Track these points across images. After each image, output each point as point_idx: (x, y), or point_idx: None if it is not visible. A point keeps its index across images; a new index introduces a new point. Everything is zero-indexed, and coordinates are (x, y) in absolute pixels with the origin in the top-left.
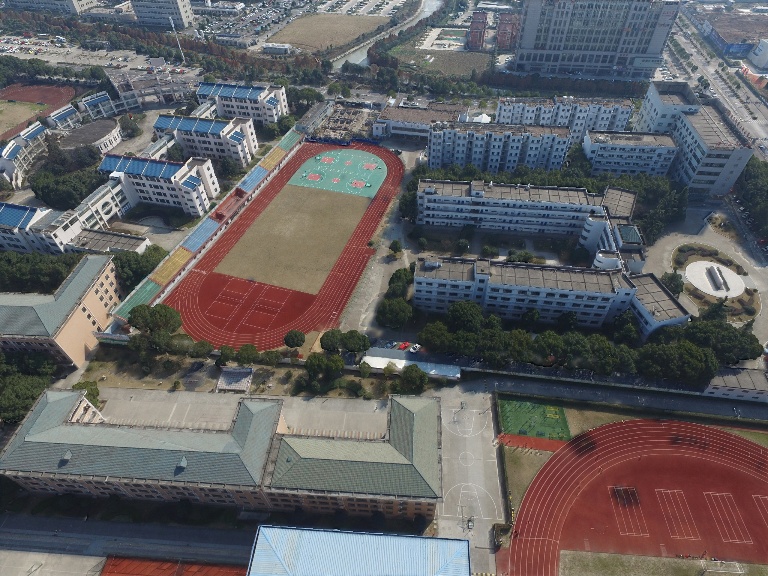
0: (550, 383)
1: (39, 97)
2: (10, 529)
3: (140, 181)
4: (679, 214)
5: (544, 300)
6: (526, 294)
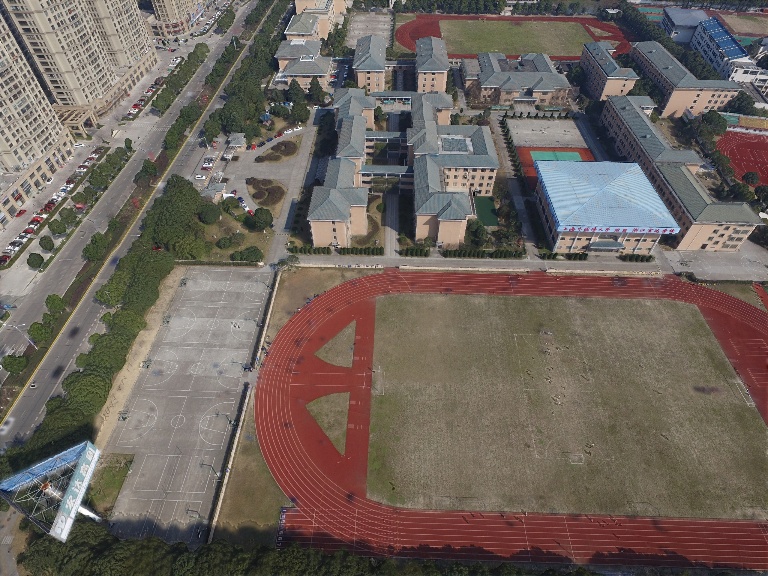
0: None
1: None
2: (582, 122)
3: None
4: None
5: None
6: None
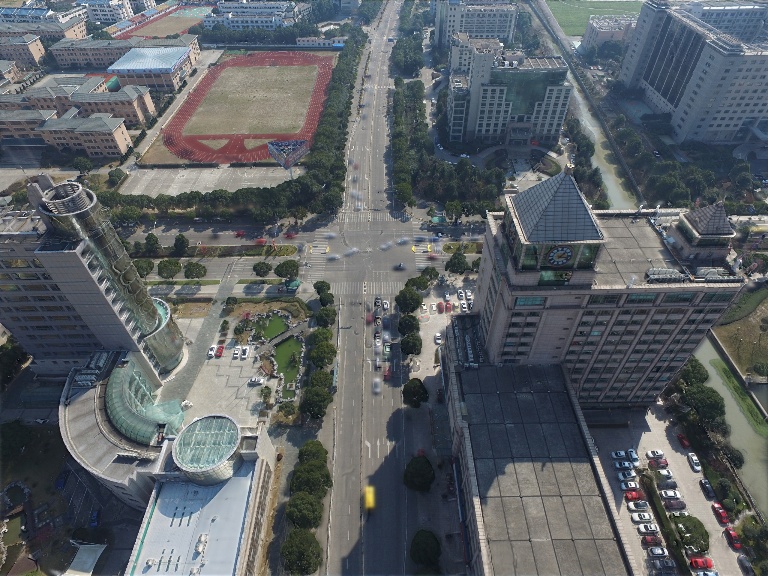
0: None
1: None
2: (55, 72)
3: (95, 8)
4: (331, 13)
5: (251, 25)
6: (244, 23)
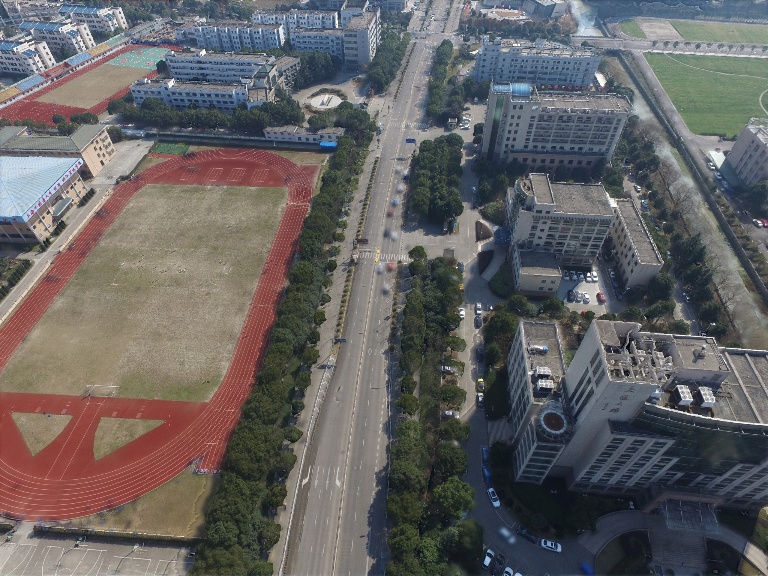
0: (192, 138)
1: None
2: None
3: None
4: (328, 72)
5: (201, 99)
6: (190, 95)
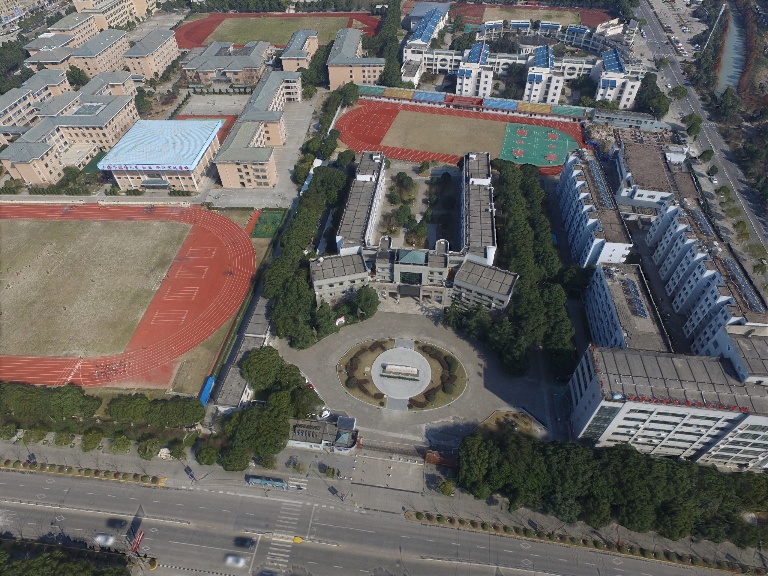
0: None
1: (591, 20)
2: None
3: None
4: None
5: None
6: None
